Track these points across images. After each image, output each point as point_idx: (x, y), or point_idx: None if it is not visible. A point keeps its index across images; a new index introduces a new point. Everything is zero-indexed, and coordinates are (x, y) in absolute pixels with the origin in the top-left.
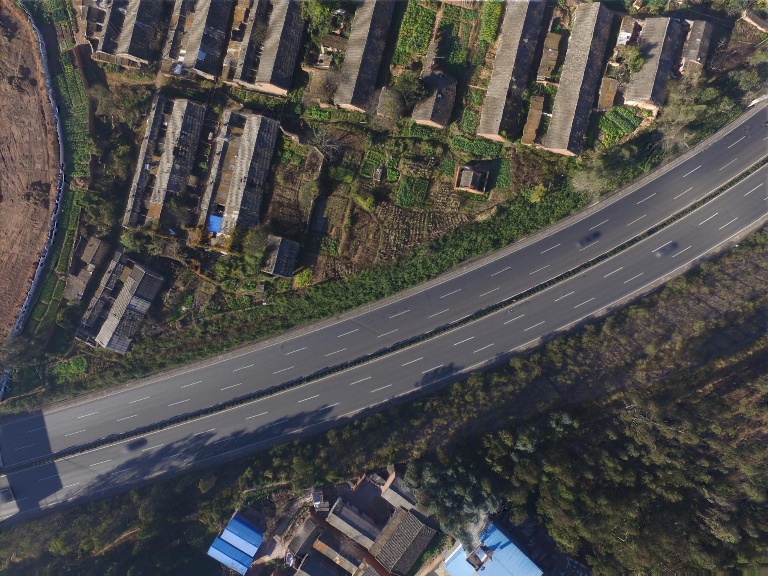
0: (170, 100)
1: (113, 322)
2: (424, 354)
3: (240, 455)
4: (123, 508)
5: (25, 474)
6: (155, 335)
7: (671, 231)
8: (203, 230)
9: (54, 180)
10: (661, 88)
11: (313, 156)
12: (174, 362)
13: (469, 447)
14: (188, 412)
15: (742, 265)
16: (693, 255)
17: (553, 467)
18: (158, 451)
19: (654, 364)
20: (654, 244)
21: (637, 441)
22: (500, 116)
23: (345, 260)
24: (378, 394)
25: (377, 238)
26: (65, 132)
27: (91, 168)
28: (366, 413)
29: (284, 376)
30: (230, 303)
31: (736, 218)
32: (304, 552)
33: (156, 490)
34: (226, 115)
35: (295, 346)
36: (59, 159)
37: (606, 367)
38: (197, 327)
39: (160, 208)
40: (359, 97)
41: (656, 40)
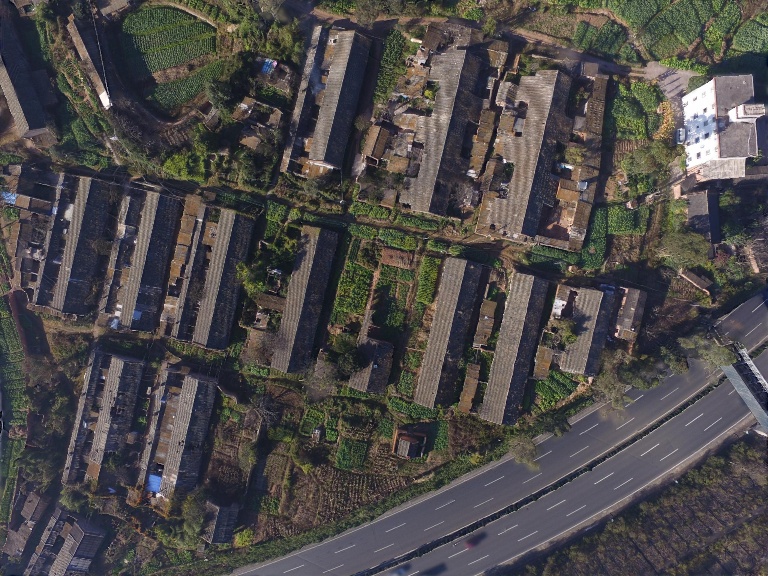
0: (107, 354)
1: None
2: None
3: None
4: None
5: None
6: None
7: (613, 462)
8: (142, 491)
9: None
10: (595, 359)
11: (252, 413)
12: None
13: None
14: None
15: (680, 509)
16: (634, 487)
17: None
18: None
19: None
20: (596, 476)
21: None
22: (435, 390)
23: (285, 521)
24: None
25: (317, 498)
26: (2, 380)
27: (29, 421)
28: None
29: None
30: (172, 558)
31: (677, 449)
32: None
33: None
34: (163, 374)
35: None
36: None
37: None
38: None
39: (98, 469)
40: (296, 364)
41: (590, 313)
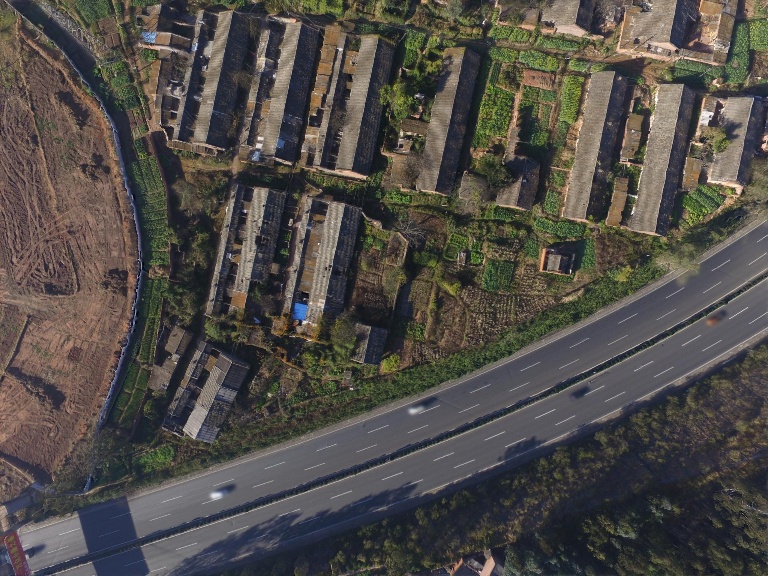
0: (249, 187)
1: (201, 413)
2: (506, 428)
3: (326, 535)
4: None
5: (111, 560)
6: (242, 423)
7: (747, 297)
8: (289, 319)
9: (132, 268)
10: (746, 167)
11: (395, 240)
12: (259, 446)
13: (565, 529)
14: (272, 493)
15: None
16: None
17: (662, 559)
18: (244, 533)
19: (746, 441)
20: (731, 311)
21: (749, 535)
22: (587, 200)
23: (432, 345)
24: (462, 469)
25: (463, 322)
26: (142, 220)
27: (171, 257)
28: (451, 489)
29: (367, 454)
30: (316, 389)
31: None
32: None
33: (247, 575)
34: (307, 202)
35: (377, 424)
36: (136, 247)
37: (696, 443)
38: (284, 414)
39: (245, 298)
40: (443, 183)
41: (740, 120)
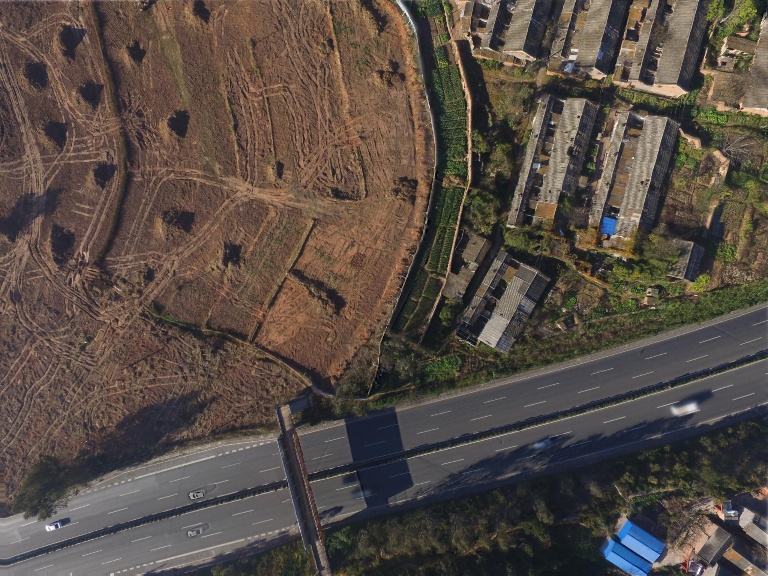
0: (558, 99)
1: (501, 322)
2: None
3: (598, 459)
4: (491, 508)
5: (376, 470)
6: (536, 336)
7: None
8: (598, 232)
9: (425, 176)
10: None
11: (709, 160)
12: (543, 363)
13: None
14: (544, 414)
15: None
16: None
17: None
18: (513, 452)
19: None
20: None
21: None
22: None
23: (746, 266)
24: (740, 402)
25: None
26: (439, 128)
27: (471, 165)
28: (729, 421)
29: (644, 381)
30: (616, 306)
31: None
32: (715, 561)
33: (525, 492)
34: (622, 116)
35: (655, 351)
36: (429, 155)
37: None
38: (582, 329)
39: (554, 208)
40: None
41: None
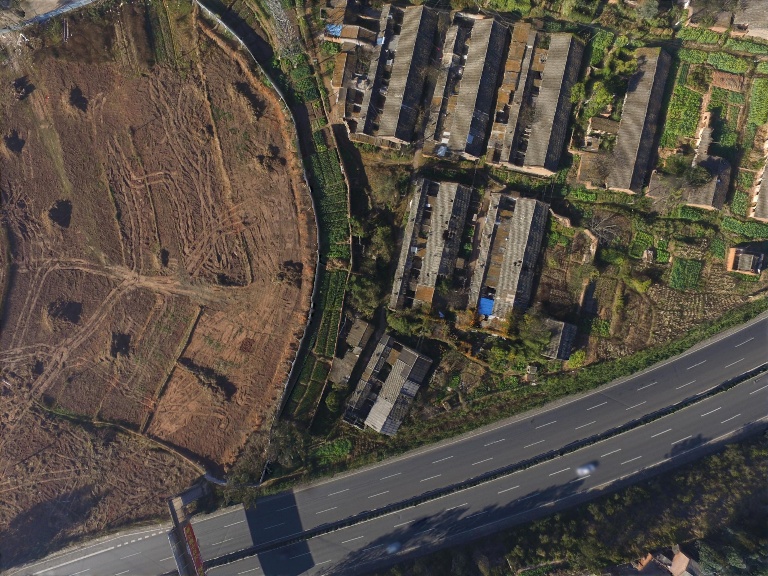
0: (433, 182)
1: (385, 406)
2: (672, 425)
3: (494, 529)
4: None
5: (277, 553)
6: (422, 416)
7: None
8: (475, 313)
9: (309, 260)
10: None
11: (580, 237)
12: (433, 440)
13: (751, 525)
14: (440, 487)
15: None
16: None
17: None
18: (411, 527)
19: None
20: None
21: None
22: None
23: (619, 341)
24: (628, 466)
25: (649, 319)
26: (320, 212)
27: (352, 250)
28: (618, 485)
29: (535, 450)
30: (498, 384)
31: None
32: None
33: (420, 568)
34: (494, 198)
35: (545, 420)
36: (312, 239)
37: None
38: (466, 408)
39: (432, 292)
40: (635, 181)
41: None
